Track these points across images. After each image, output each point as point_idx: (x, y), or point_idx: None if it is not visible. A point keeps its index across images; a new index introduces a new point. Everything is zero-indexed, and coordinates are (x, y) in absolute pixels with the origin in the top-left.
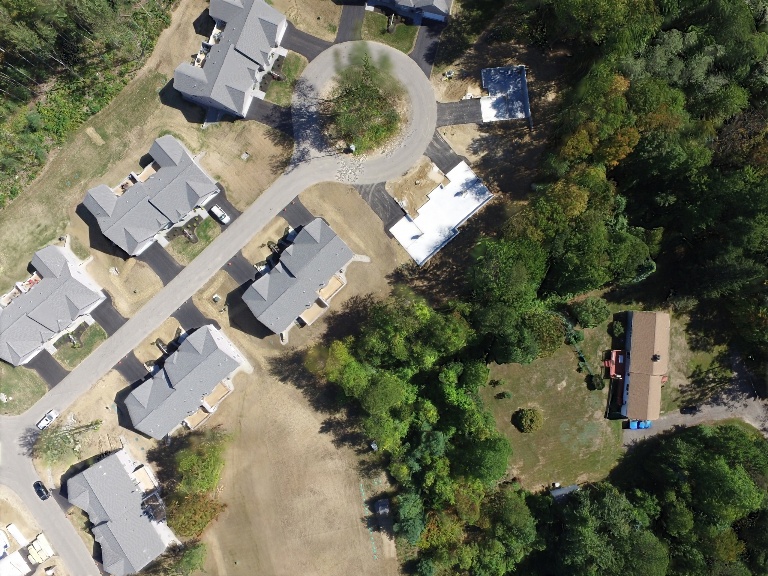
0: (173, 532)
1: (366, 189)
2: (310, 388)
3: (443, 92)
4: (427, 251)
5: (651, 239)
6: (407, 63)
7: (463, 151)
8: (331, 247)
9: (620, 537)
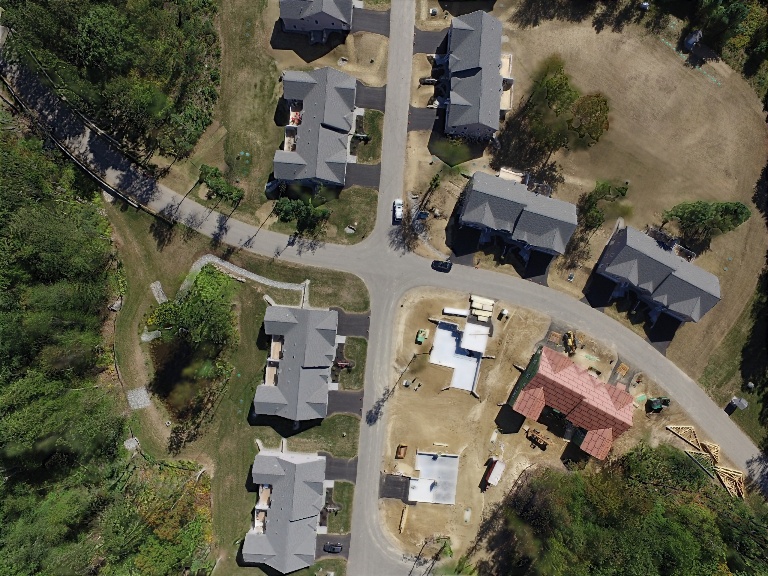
0: None
1: None
2: (560, 11)
3: None
4: None
5: None
6: None
7: None
8: None
9: None
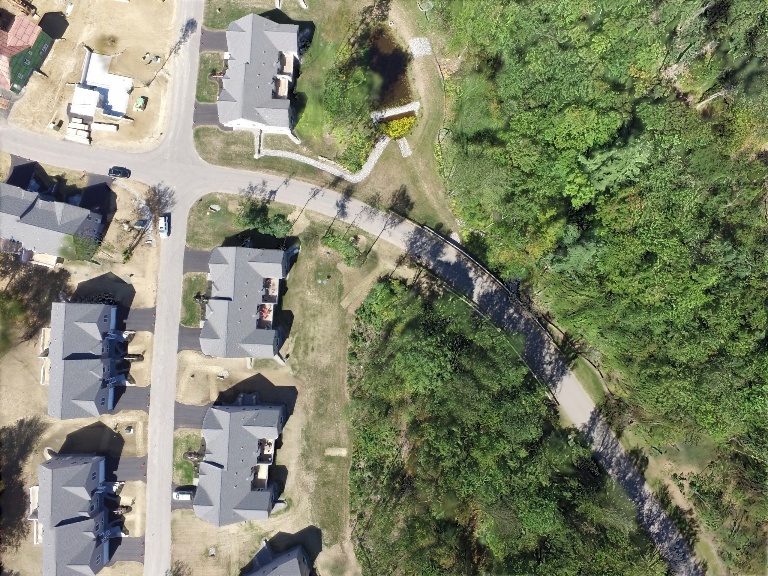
0: None
1: None
2: None
3: None
4: None
5: None
6: None
7: None
8: None
9: None
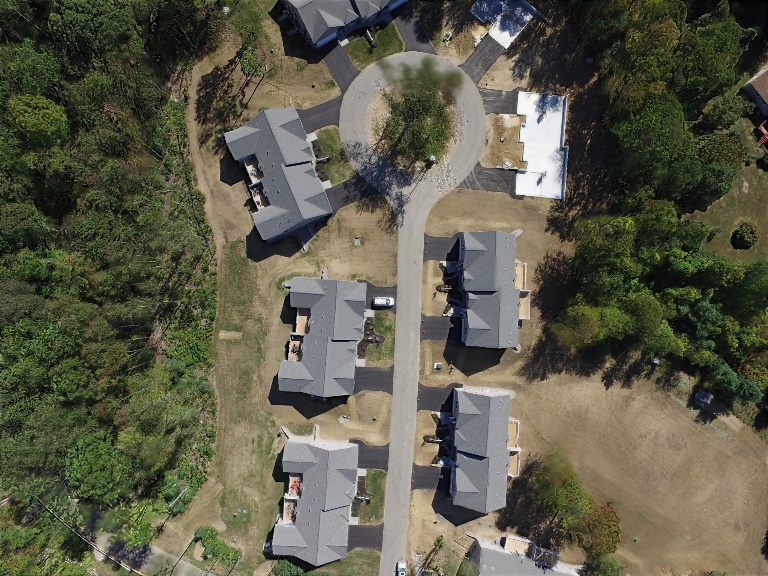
0: (569, 563)
1: (469, 181)
2: (568, 365)
3: (456, 55)
4: (557, 183)
5: (722, 16)
6: (410, 58)
7: (512, 85)
8: (499, 244)
9: None
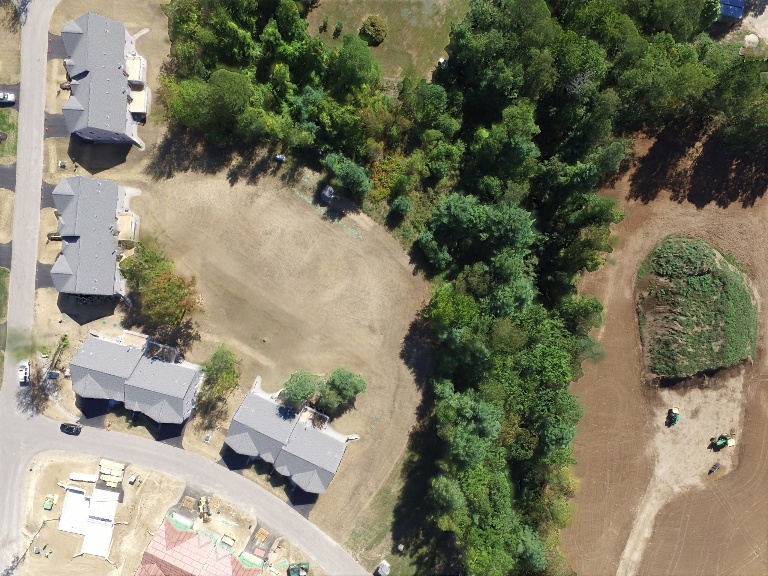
0: (197, 364)
1: None
2: (194, 163)
3: None
4: None
5: None
6: None
7: None
8: (94, 27)
9: (498, 23)
